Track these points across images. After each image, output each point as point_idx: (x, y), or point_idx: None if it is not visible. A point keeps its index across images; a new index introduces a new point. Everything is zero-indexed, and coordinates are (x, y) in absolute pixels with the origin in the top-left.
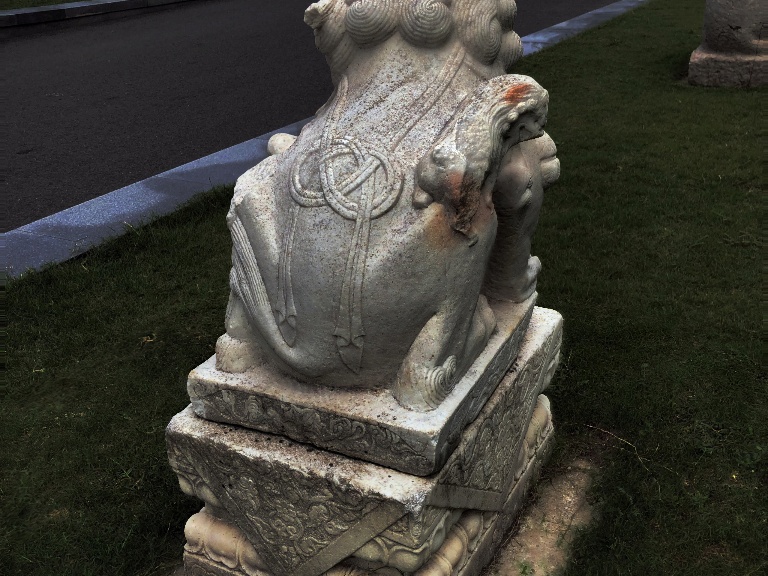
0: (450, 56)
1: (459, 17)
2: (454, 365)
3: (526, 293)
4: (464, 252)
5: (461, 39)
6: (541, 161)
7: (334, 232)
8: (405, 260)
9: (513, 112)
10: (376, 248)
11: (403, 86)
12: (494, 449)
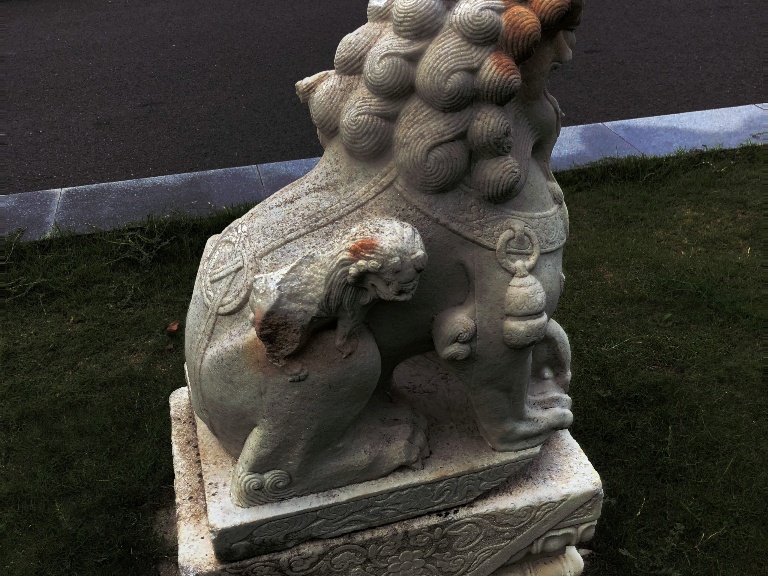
0: (378, 174)
1: (398, 134)
2: (281, 480)
3: (511, 445)
4: (284, 384)
5: (395, 159)
6: (508, 317)
7: (197, 311)
8: (225, 366)
9: (353, 267)
10: (216, 342)
11: (319, 192)
12: (378, 575)
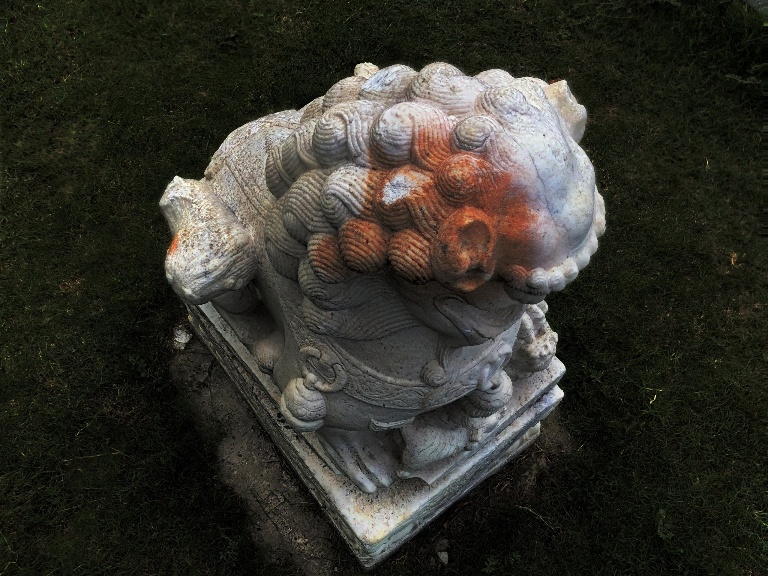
0: None
1: None
2: None
3: None
4: None
5: None
6: None
7: None
8: None
9: None
10: None
11: None
12: None
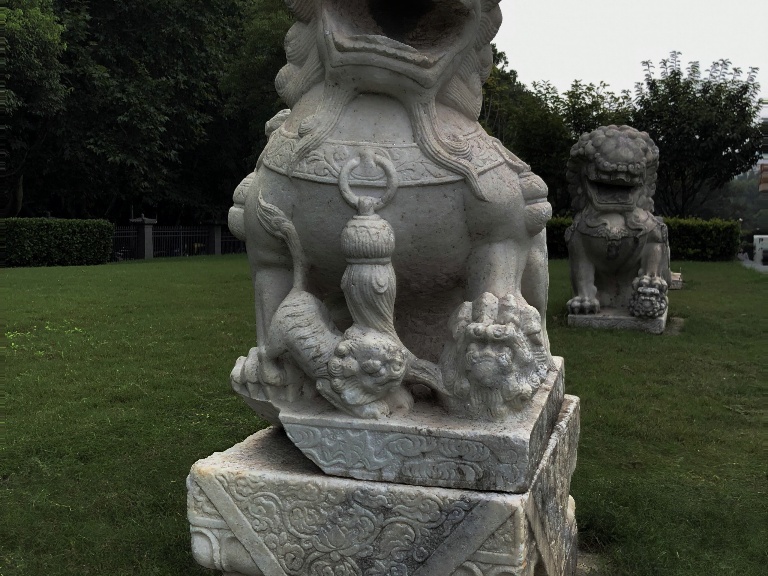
0: None
1: None
2: None
3: None
4: None
5: None
6: None
7: None
8: None
9: None
10: None
11: None
12: None
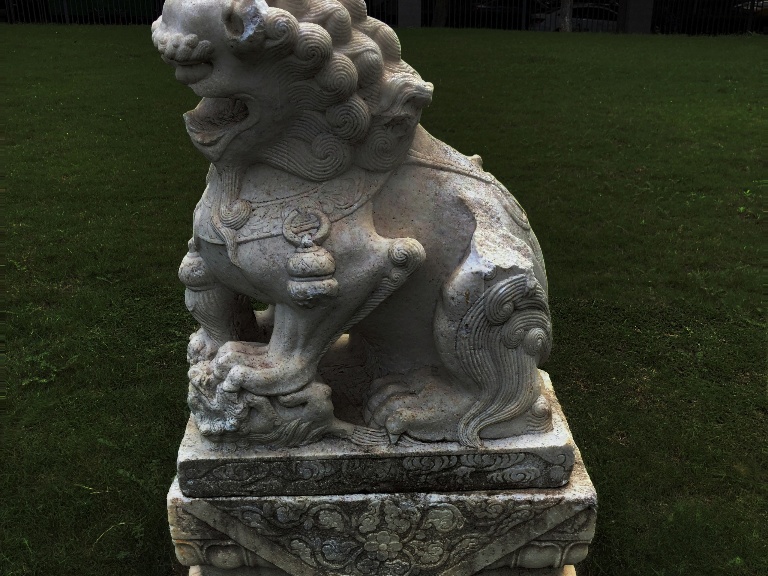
0: None
1: None
2: None
3: None
4: None
5: None
6: None
7: None
8: None
9: None
10: None
11: None
12: None
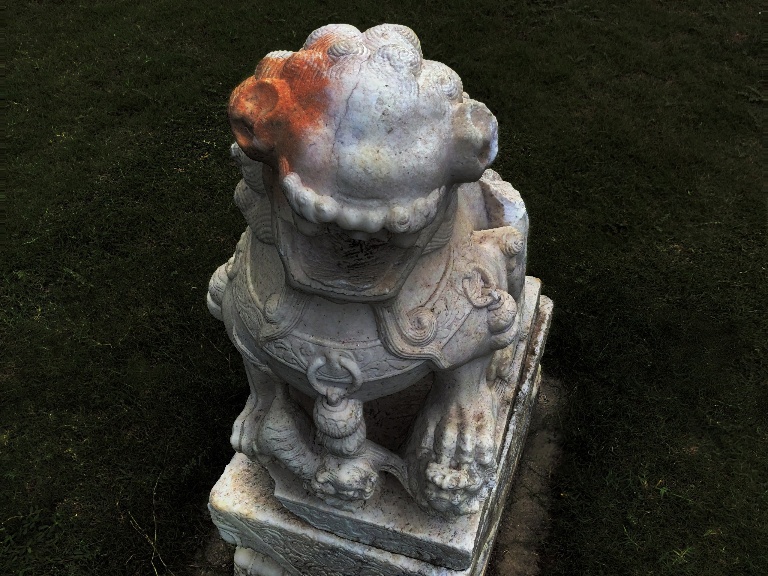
0: None
1: None
2: None
3: None
4: None
5: None
6: None
7: None
8: None
9: None
10: None
11: None
12: None
